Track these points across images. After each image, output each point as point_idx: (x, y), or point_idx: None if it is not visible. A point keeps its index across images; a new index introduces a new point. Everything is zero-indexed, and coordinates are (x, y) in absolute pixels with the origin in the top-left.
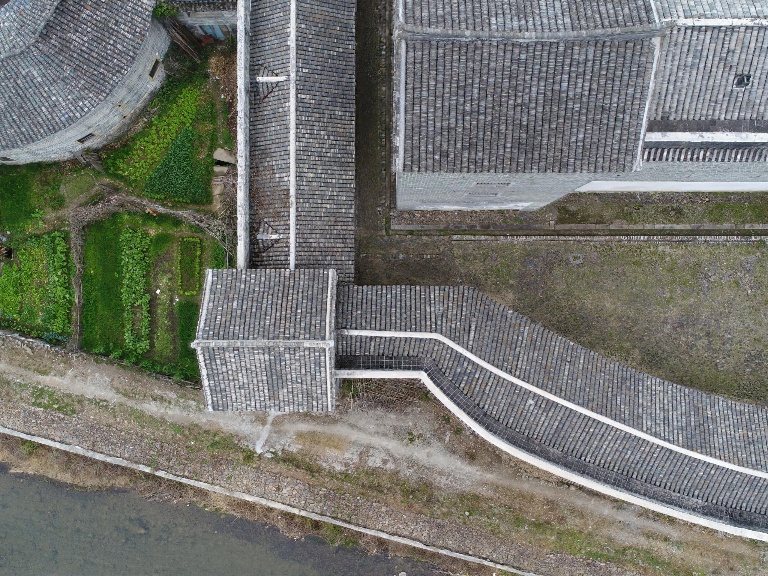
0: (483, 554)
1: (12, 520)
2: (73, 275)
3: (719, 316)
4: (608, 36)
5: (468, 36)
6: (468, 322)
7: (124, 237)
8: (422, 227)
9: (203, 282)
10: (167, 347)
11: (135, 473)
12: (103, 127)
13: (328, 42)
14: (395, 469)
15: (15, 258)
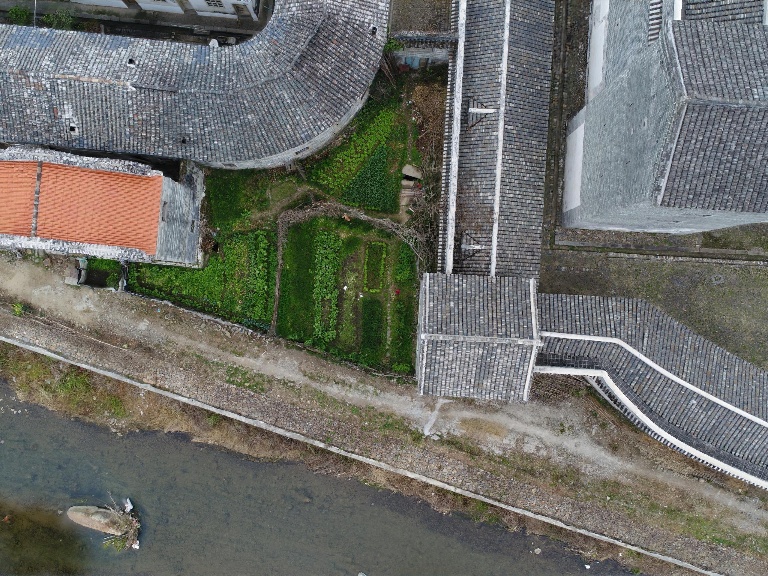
0: (617, 535)
1: (190, 484)
2: (273, 269)
3: None
4: None
5: (740, 104)
6: (642, 330)
7: (319, 238)
8: (583, 244)
9: (385, 282)
10: (351, 337)
11: (306, 448)
12: (318, 142)
13: (530, 81)
14: (547, 456)
15: (220, 251)
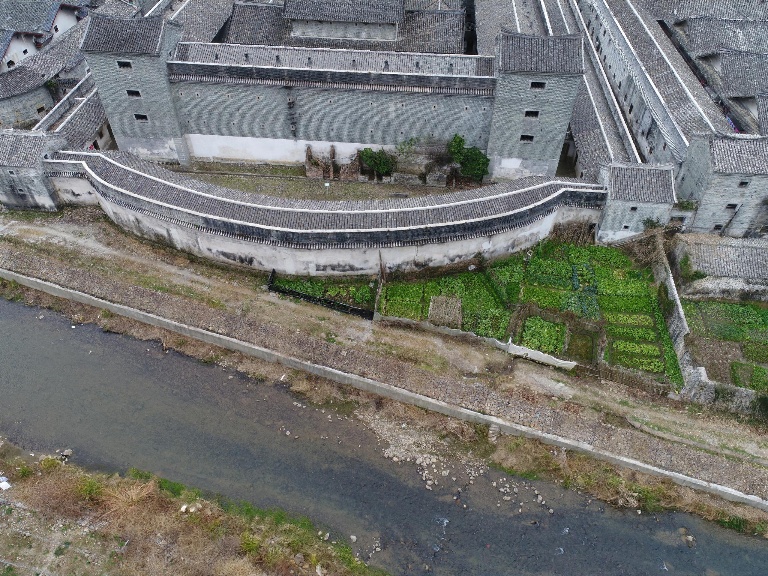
0: (93, 292)
1: None
2: None
3: None
4: (150, 19)
5: (109, 16)
6: None
7: None
8: None
9: None
10: None
11: None
12: (6, 120)
13: None
14: (63, 245)
15: None
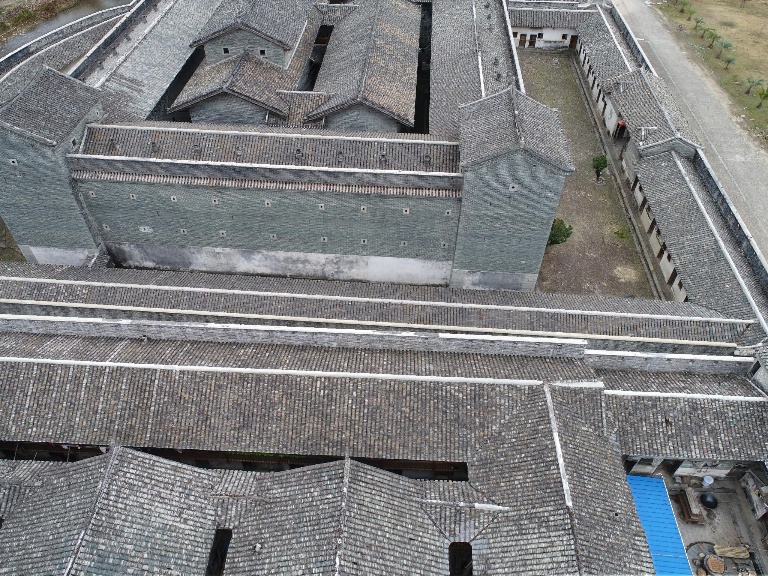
0: None
1: None
2: None
3: None
4: None
5: None
6: None
7: None
8: None
9: None
10: None
11: None
12: None
13: None
14: None
15: None
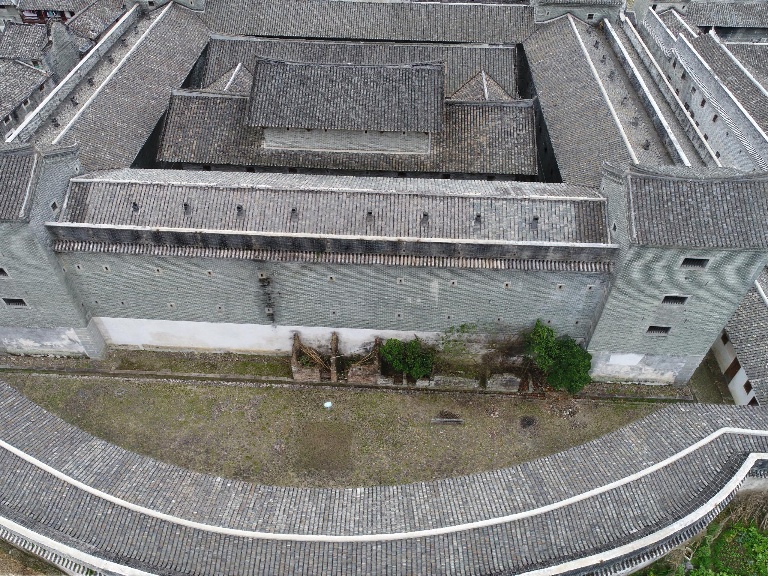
0: None
1: None
2: None
3: (220, 437)
4: (11, 153)
5: None
6: None
7: None
8: (12, 367)
9: None
10: None
11: None
12: None
13: None
14: None
15: None
